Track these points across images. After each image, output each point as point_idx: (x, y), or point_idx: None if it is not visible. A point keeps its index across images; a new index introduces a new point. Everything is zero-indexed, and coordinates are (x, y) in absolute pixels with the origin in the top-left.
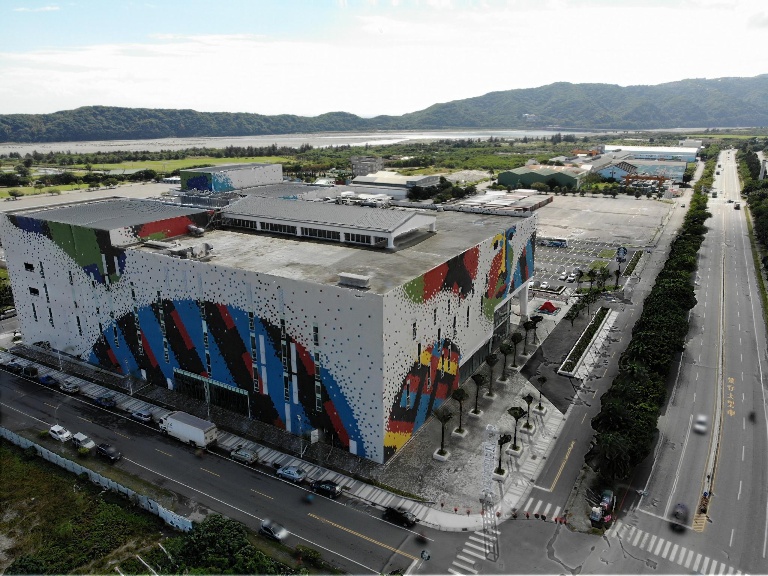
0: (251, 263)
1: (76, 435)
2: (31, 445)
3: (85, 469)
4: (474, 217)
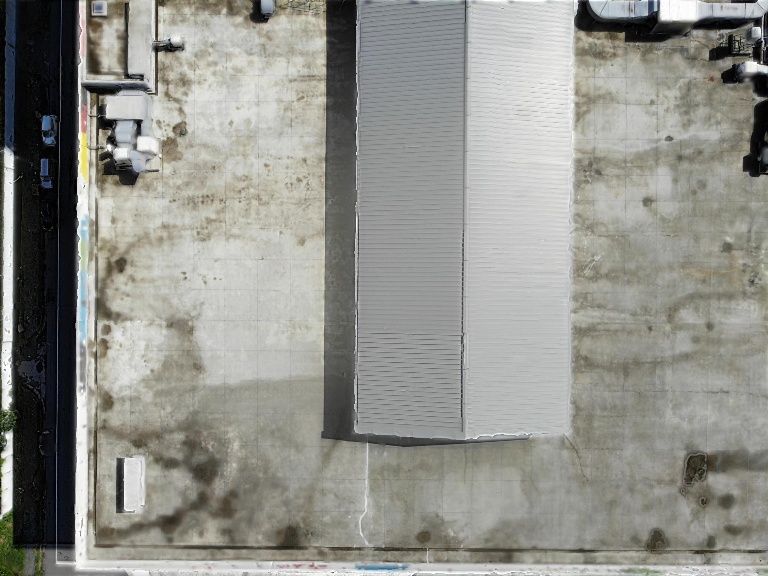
0: (151, 261)
1: (42, 161)
2: (7, 137)
3: (4, 234)
4: (760, 432)
